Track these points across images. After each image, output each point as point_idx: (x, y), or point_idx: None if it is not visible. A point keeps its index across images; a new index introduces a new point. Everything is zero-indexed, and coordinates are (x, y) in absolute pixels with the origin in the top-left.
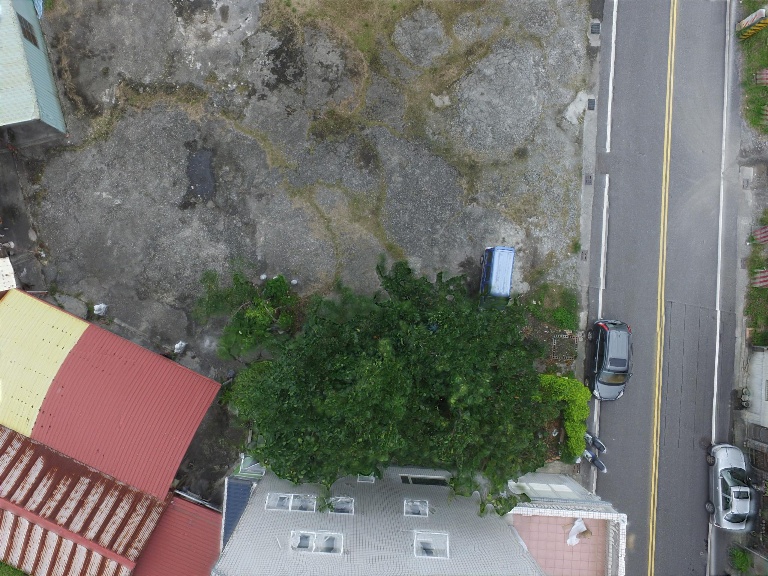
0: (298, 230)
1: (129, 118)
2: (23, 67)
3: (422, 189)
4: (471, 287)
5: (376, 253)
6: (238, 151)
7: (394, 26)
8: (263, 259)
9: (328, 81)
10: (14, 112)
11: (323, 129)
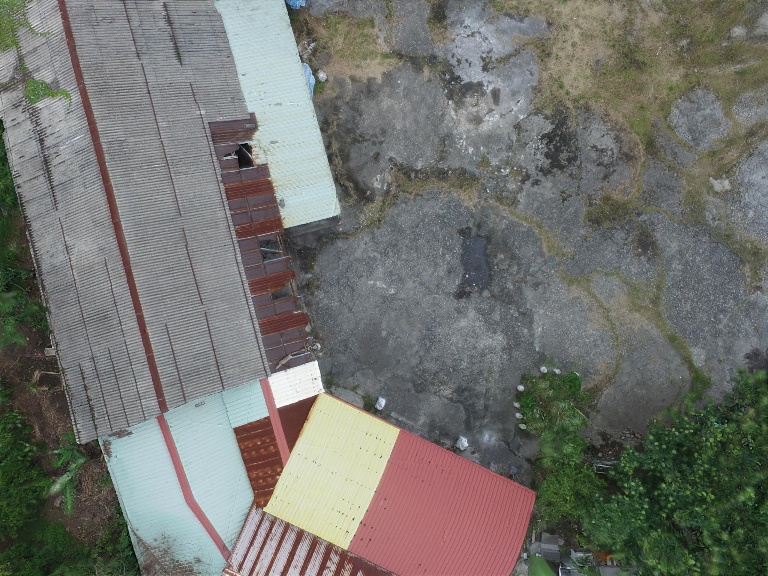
0: (576, 320)
1: (401, 205)
2: (324, 162)
3: (704, 277)
4: (757, 379)
5: (658, 344)
6: (513, 238)
7: (670, 108)
8: (541, 350)
9: (603, 165)
10: (317, 209)
11: (599, 215)
